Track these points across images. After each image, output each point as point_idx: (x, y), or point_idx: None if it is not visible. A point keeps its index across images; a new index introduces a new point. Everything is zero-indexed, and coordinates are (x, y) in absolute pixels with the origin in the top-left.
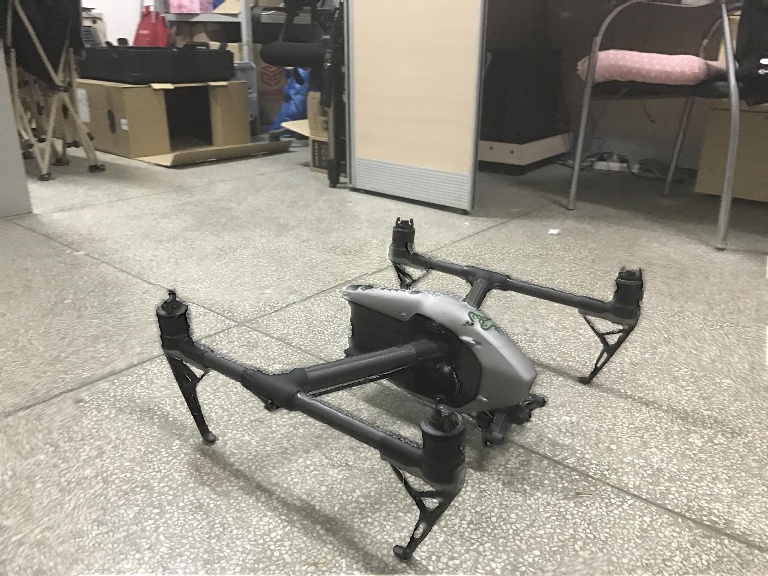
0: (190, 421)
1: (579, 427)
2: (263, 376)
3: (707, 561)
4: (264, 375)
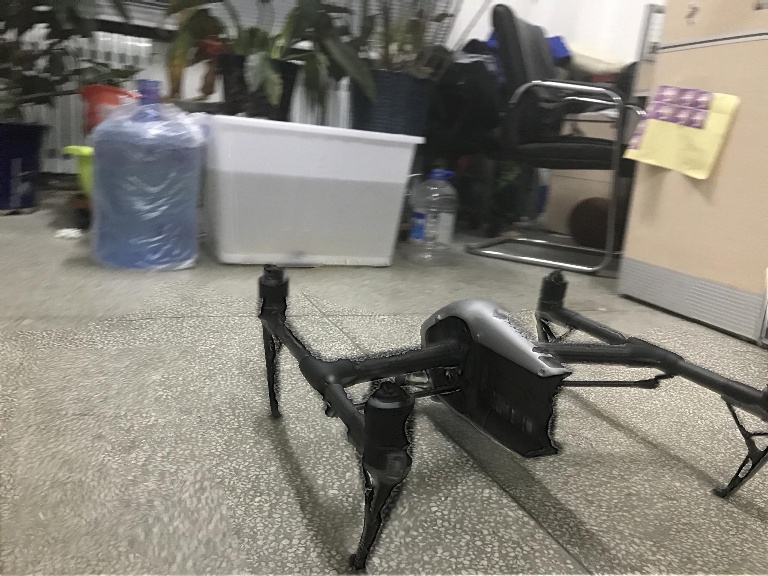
0: (760, 524)
1: (351, 396)
2: (663, 352)
3: (389, 349)
4: (663, 352)
